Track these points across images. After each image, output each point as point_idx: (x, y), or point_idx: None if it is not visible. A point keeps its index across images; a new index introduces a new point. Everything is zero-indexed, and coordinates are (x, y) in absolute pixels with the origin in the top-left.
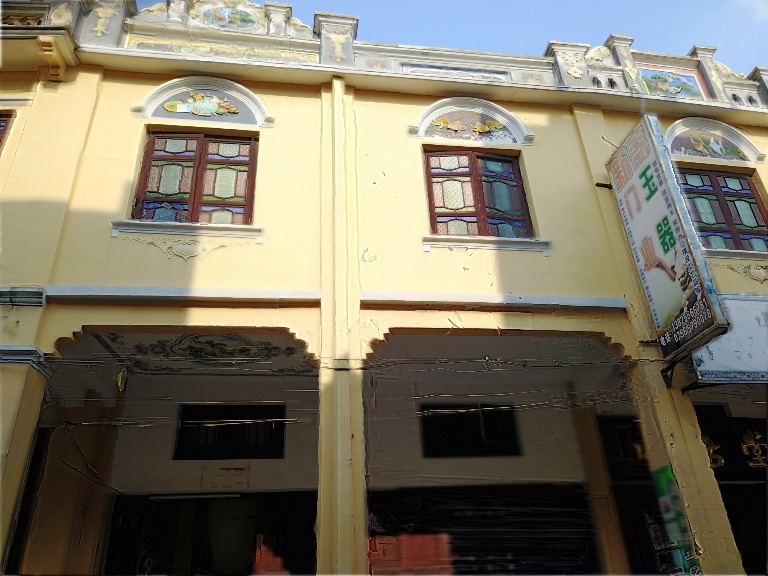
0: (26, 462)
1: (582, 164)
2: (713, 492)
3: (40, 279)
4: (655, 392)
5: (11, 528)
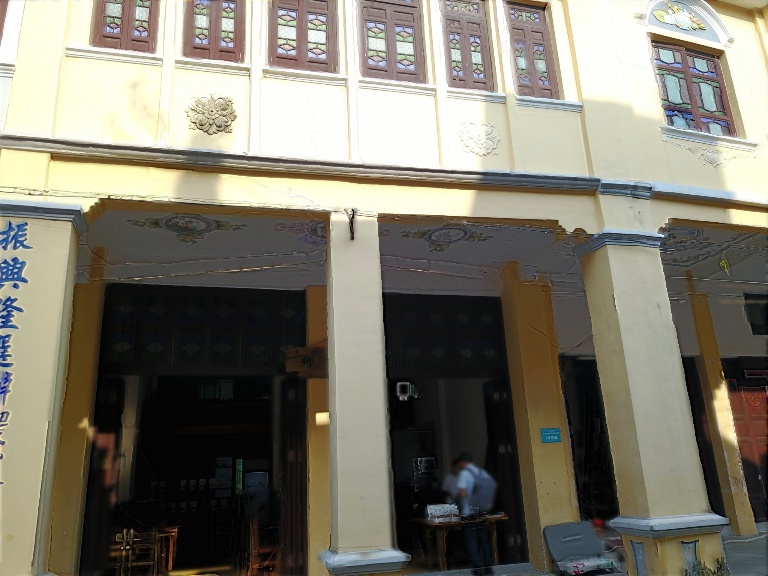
0: None
1: None
2: None
3: (639, 175)
4: None
5: None
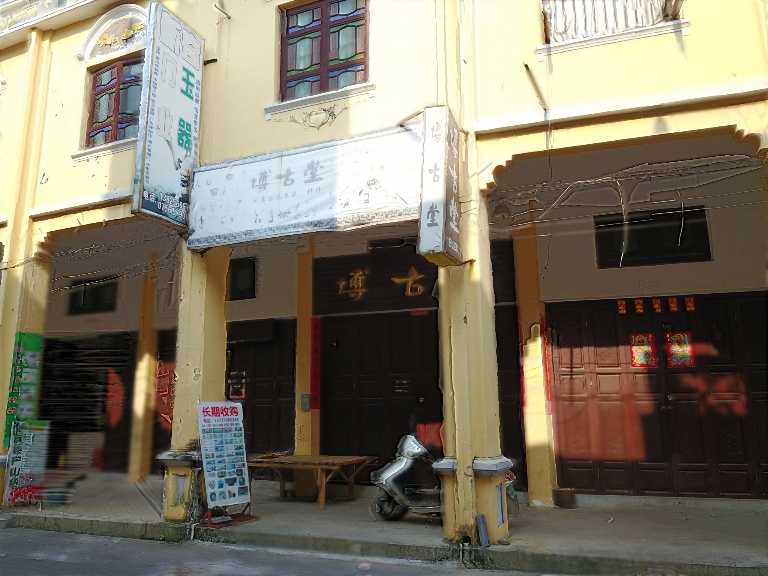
0: None
1: None
2: (197, 335)
3: None
4: (183, 258)
5: None
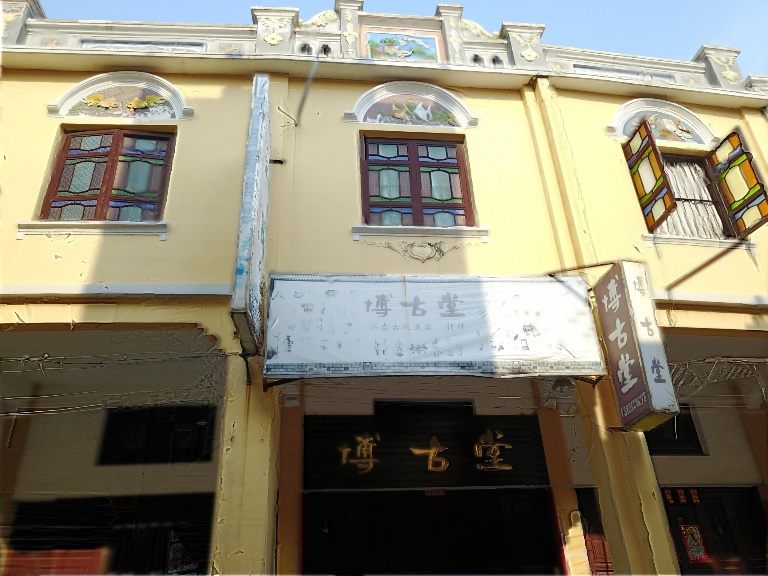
0: None
1: (246, 138)
2: (259, 505)
3: None
4: (231, 390)
5: None
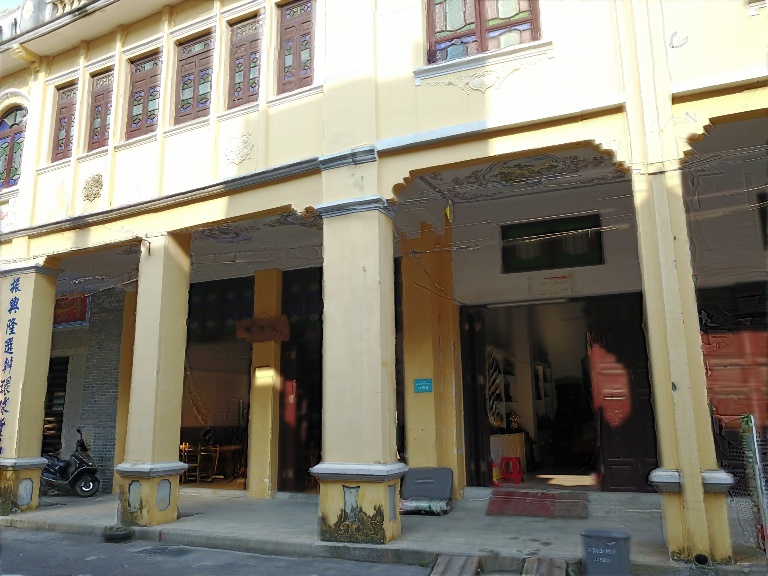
0: (392, 285)
1: None
2: None
3: (369, 138)
4: None
5: (393, 333)
